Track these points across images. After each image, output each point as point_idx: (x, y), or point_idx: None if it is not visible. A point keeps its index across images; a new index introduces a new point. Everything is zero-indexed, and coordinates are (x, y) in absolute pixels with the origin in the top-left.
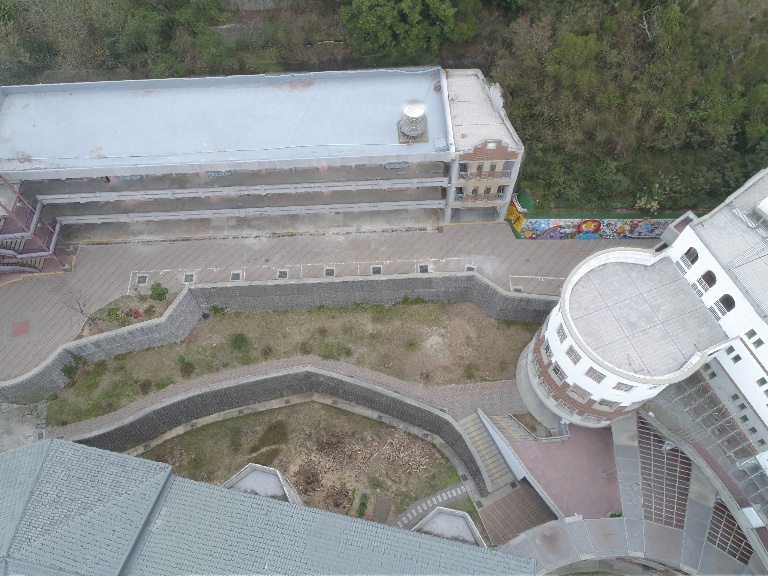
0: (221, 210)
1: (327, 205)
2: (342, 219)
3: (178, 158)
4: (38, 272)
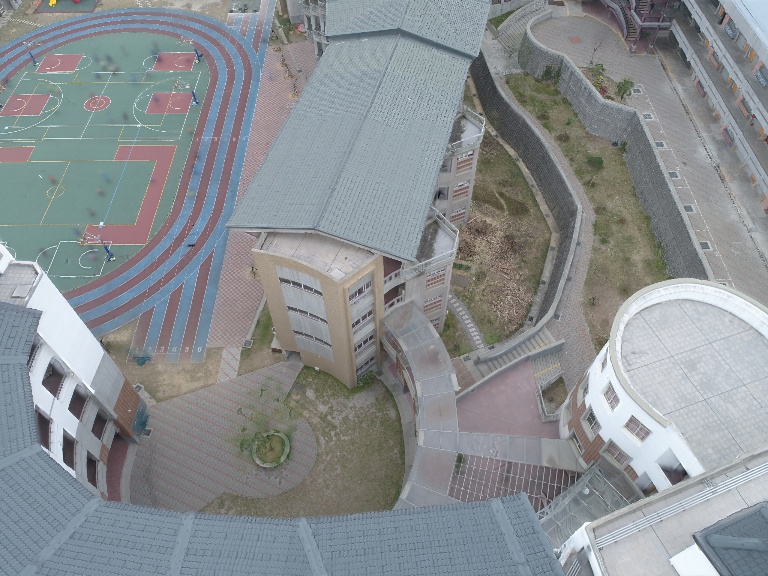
0: (724, 103)
1: (766, 173)
2: (760, 216)
3: (760, 33)
4: (625, 38)
